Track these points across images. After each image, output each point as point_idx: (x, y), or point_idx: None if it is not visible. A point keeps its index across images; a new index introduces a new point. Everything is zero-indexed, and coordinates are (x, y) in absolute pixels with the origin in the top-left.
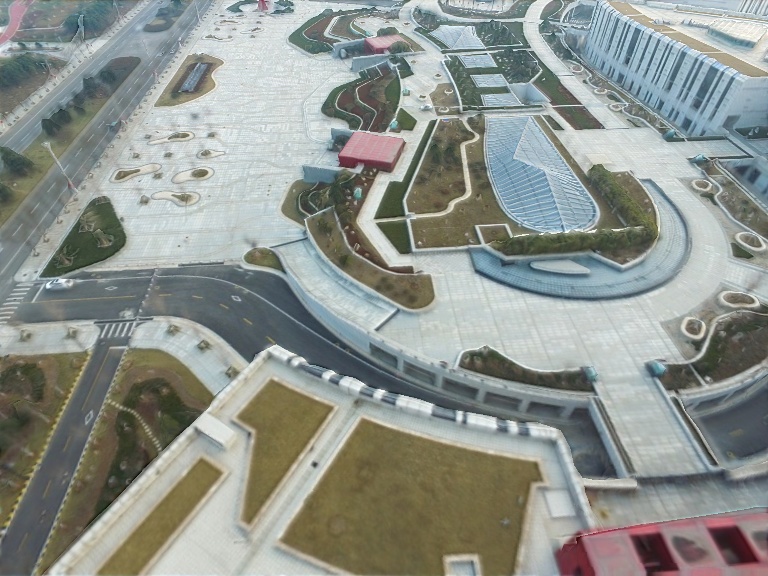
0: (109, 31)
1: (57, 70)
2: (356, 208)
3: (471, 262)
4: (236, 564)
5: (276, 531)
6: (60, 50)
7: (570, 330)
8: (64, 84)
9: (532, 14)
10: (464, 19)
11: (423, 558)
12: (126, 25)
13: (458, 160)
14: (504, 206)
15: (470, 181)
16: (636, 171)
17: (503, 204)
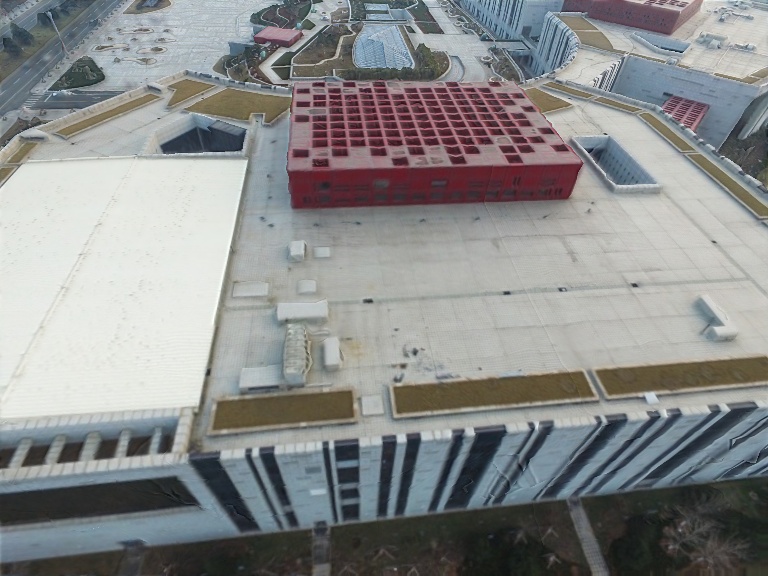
0: None
1: None
2: (260, 61)
3: None
4: None
5: None
6: None
7: None
8: None
9: None
10: None
11: None
12: None
13: (335, 43)
14: (355, 62)
15: (339, 52)
16: (450, 52)
17: (355, 61)
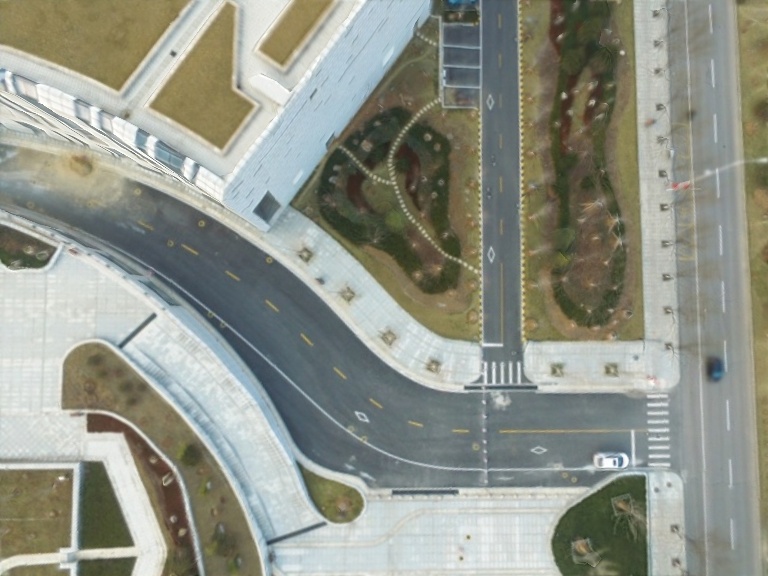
0: None
1: None
2: None
3: None
4: None
5: None
6: None
7: None
8: None
9: None
10: None
11: None
12: None
13: None
14: None
15: None
16: None
17: None
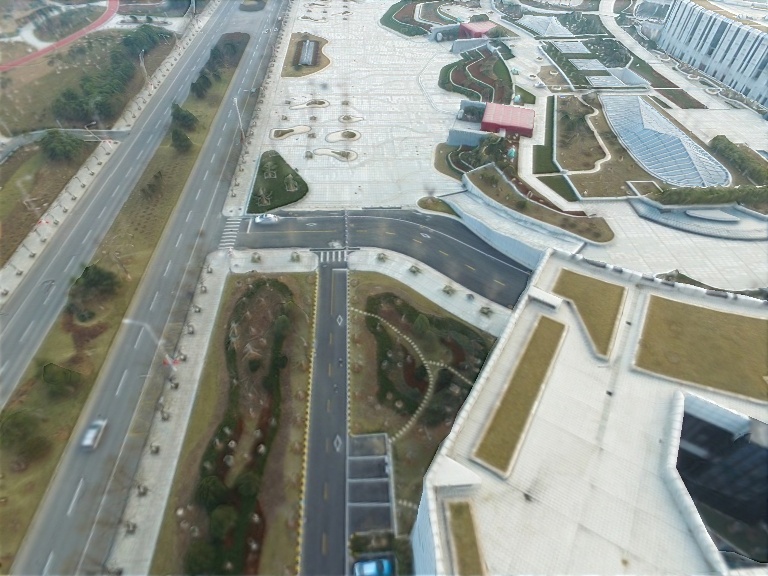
0: (209, 9)
1: (180, 41)
2: (514, 165)
3: (633, 209)
4: (608, 379)
5: (627, 361)
6: (170, 24)
7: (738, 262)
8: (187, 54)
9: (605, 8)
10: (543, 10)
11: (749, 377)
12: (220, 4)
13: (589, 129)
14: (645, 167)
15: (606, 147)
16: (749, 144)
17: (644, 165)
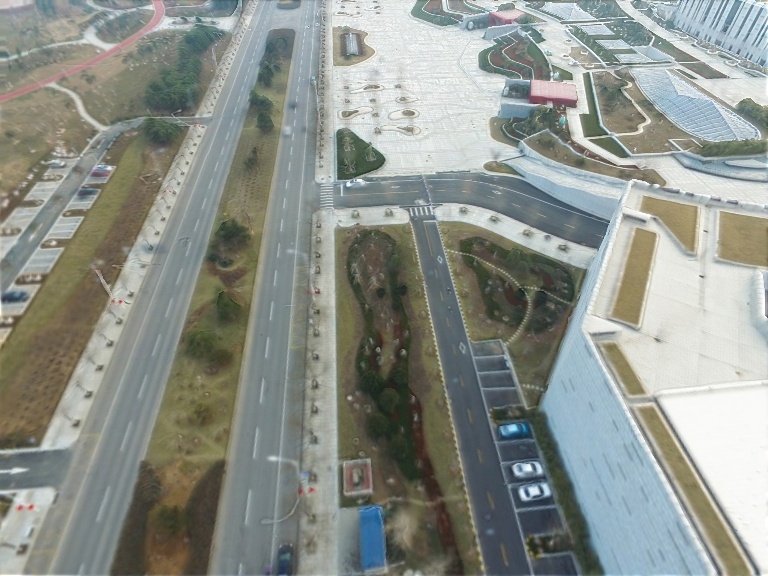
0: (250, 8)
1: (235, 38)
2: (566, 130)
3: (678, 162)
4: (698, 268)
5: (710, 255)
6: (218, 23)
7: None
8: (242, 50)
9: None
10: None
11: None
12: (258, 4)
13: (627, 99)
14: (683, 128)
15: (645, 113)
16: None
17: (682, 126)
